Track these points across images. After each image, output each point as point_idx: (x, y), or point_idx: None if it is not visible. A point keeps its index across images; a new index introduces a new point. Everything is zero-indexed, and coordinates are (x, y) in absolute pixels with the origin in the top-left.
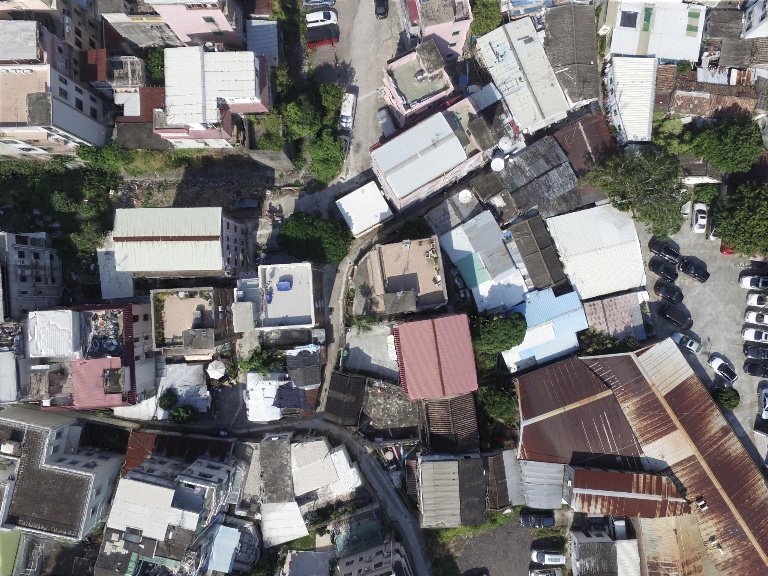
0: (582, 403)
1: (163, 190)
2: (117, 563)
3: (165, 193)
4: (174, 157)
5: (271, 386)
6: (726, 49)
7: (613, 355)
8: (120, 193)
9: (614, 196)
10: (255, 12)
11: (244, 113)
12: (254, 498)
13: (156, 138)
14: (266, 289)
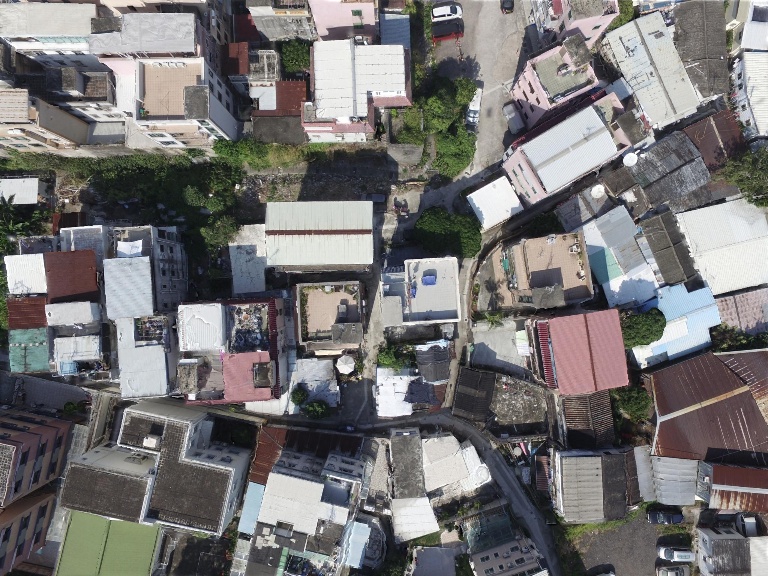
0: (719, 399)
1: (288, 185)
2: (269, 557)
3: (290, 188)
4: (307, 151)
5: (402, 381)
6: None
7: (749, 351)
8: (245, 188)
9: (746, 191)
10: (389, 6)
11: (386, 107)
12: (380, 494)
13: (292, 132)
14: (410, 283)
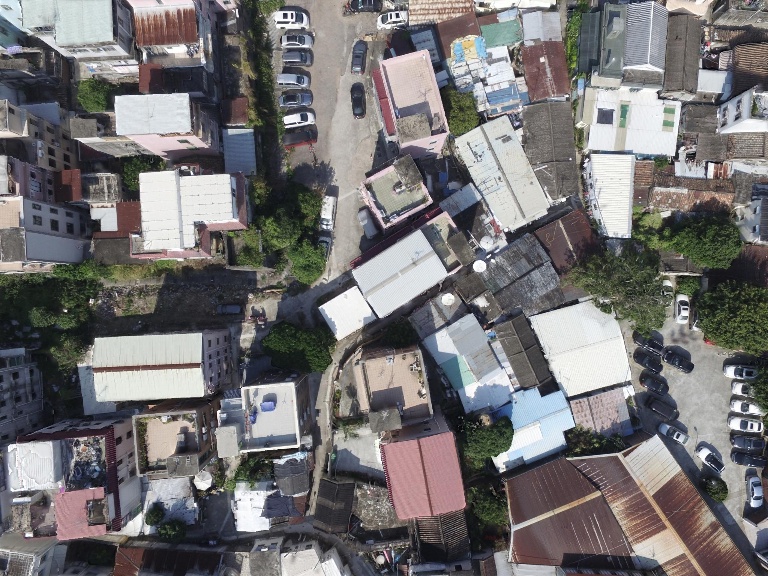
0: (571, 506)
1: (144, 297)
2: None
3: (146, 300)
4: (154, 269)
5: (259, 496)
6: (702, 143)
7: (600, 456)
8: (100, 301)
9: (596, 293)
10: (231, 122)
11: (223, 230)
12: None
13: None
14: (250, 409)
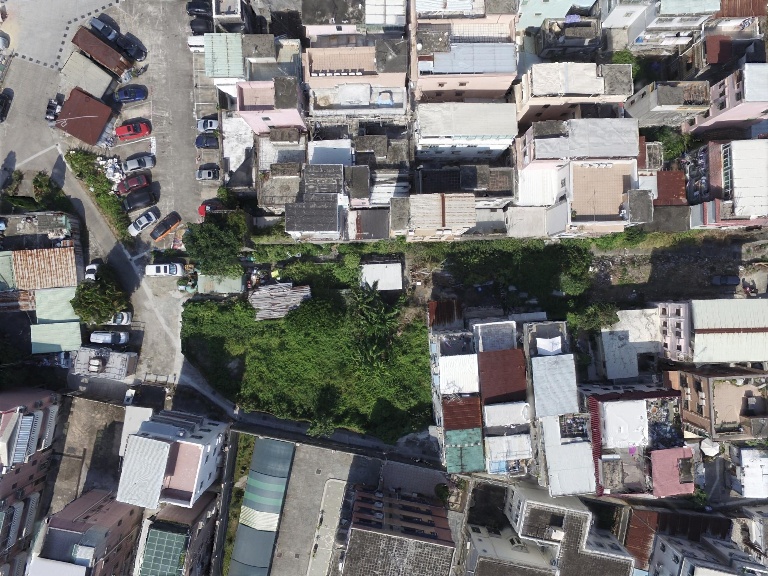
0: None
1: (638, 266)
2: None
3: (640, 269)
4: (679, 238)
5: None
6: None
7: None
8: (597, 270)
9: None
10: None
11: None
12: None
13: (674, 221)
14: None
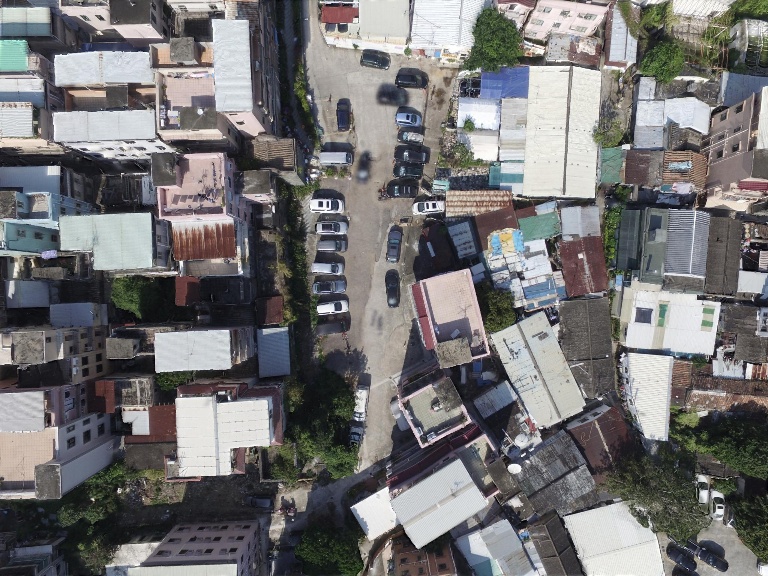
0: None
1: (172, 485)
2: None
3: (174, 488)
4: None
5: None
6: (741, 344)
7: None
8: (128, 490)
9: None
10: (266, 322)
11: None
12: None
13: None
14: None
